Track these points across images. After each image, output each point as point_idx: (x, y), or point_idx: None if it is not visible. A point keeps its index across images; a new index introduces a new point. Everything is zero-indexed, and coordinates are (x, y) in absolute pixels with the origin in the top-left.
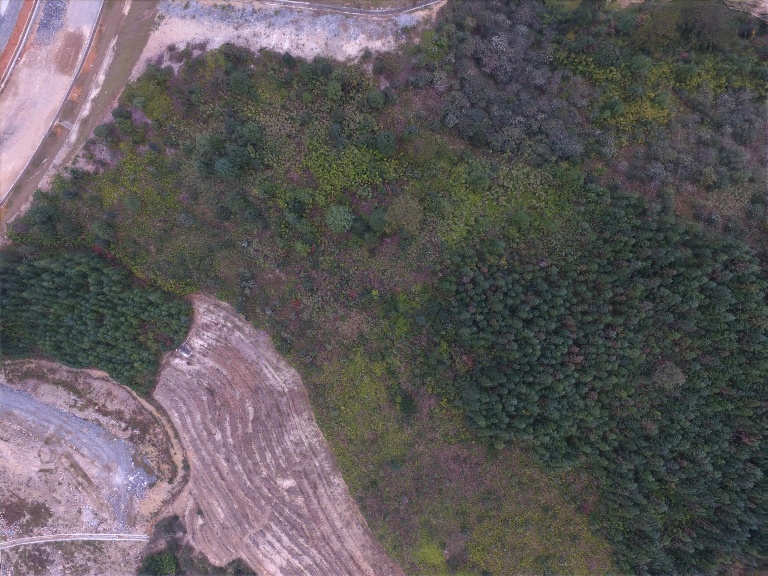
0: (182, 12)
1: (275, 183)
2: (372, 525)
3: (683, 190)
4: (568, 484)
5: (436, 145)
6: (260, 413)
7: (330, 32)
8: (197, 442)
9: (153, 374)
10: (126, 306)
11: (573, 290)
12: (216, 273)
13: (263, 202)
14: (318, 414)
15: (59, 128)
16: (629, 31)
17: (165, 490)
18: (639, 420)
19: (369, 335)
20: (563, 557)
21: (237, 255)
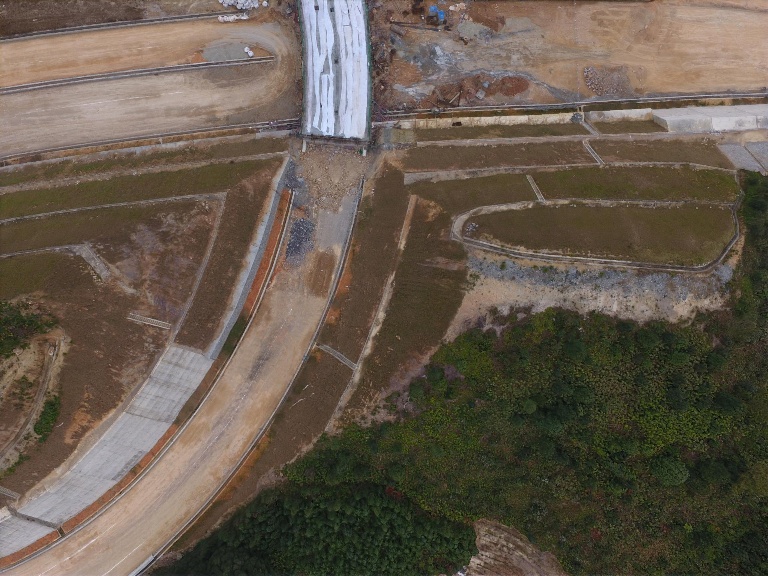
0: (499, 272)
1: (596, 434)
2: None
3: None
4: None
5: None
6: None
7: (658, 293)
8: None
9: None
10: (413, 540)
11: None
12: (506, 502)
13: (573, 445)
14: None
15: (319, 352)
16: None
17: None
18: None
19: (673, 561)
20: None
21: (532, 487)
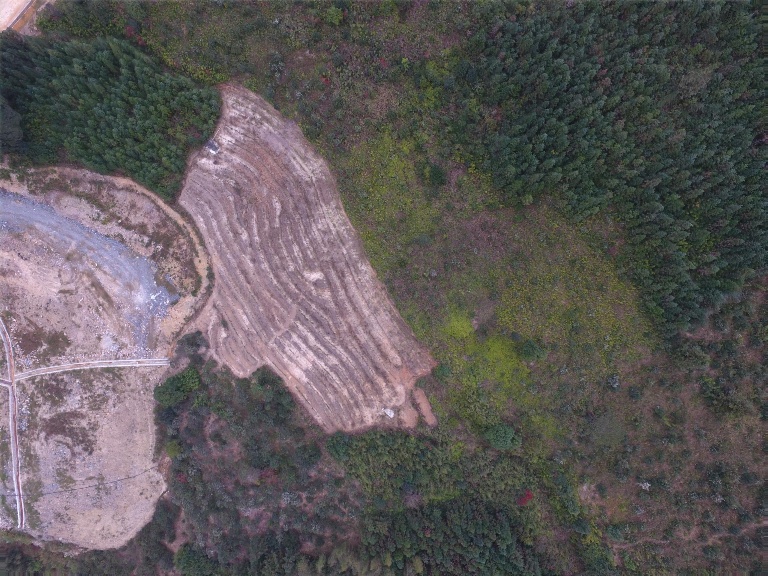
0: None
1: None
2: (400, 305)
3: None
4: (595, 232)
5: None
6: (288, 206)
7: None
8: (223, 245)
9: (180, 174)
10: (156, 93)
11: (599, 21)
12: (246, 58)
13: None
14: (346, 198)
15: None
16: None
17: (188, 305)
18: (665, 141)
19: (398, 110)
20: (590, 308)
21: (268, 36)
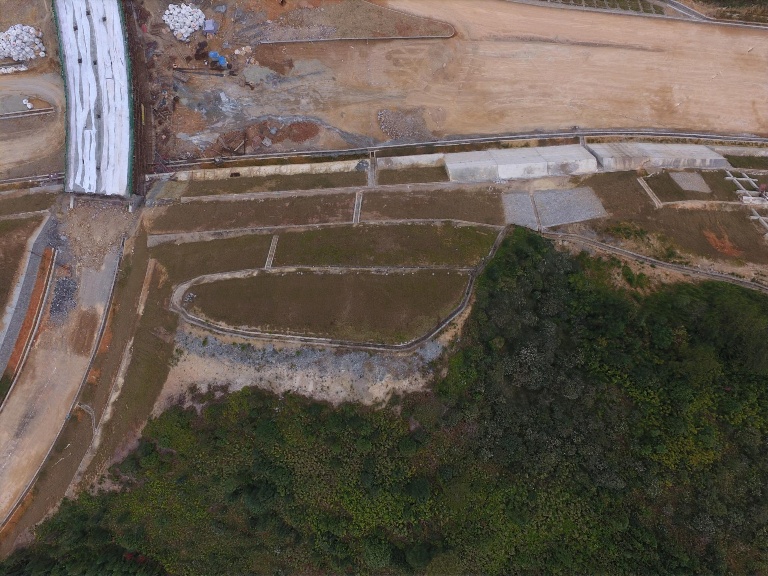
0: (201, 349)
1: (306, 511)
2: None
3: (735, 550)
4: None
5: (470, 476)
6: None
7: (355, 373)
8: None
9: None
10: None
11: None
12: (249, 569)
13: None
14: None
15: (80, 412)
16: (665, 347)
17: None
18: None
19: None
20: None
21: (270, 556)
